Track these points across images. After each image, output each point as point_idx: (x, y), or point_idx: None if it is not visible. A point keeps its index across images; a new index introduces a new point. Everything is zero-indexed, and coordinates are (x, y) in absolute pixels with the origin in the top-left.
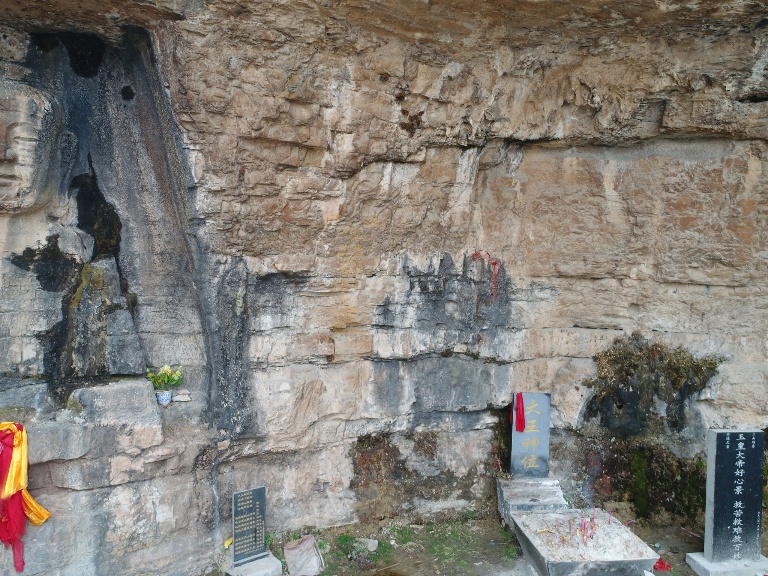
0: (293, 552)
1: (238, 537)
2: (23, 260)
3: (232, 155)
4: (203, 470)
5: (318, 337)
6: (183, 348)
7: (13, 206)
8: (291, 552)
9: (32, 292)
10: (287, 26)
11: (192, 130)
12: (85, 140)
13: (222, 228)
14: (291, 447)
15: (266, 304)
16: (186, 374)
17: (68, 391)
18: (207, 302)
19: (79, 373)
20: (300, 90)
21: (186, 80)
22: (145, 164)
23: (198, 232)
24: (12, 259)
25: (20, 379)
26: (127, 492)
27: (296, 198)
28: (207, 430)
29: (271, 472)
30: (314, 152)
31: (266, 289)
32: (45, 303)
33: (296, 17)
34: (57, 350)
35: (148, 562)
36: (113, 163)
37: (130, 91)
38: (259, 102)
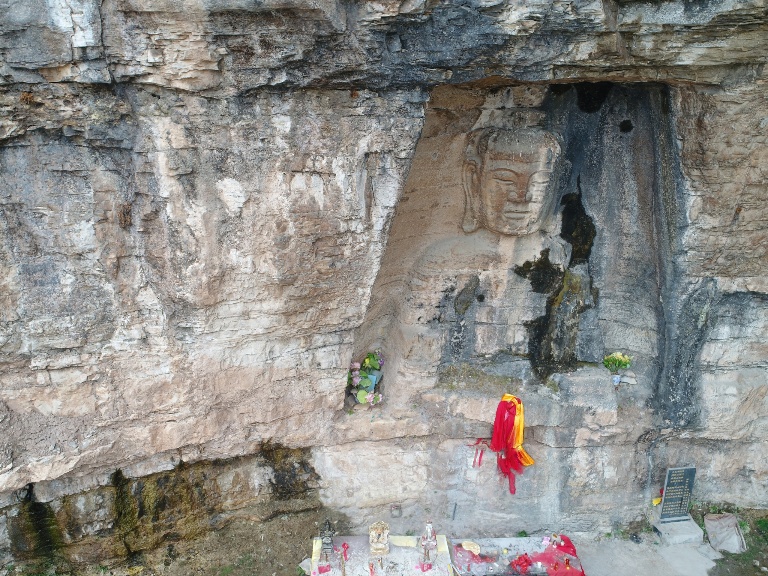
0: (713, 523)
1: (667, 502)
2: (523, 270)
3: (734, 201)
4: (643, 444)
5: None
6: (633, 337)
7: None
8: (711, 522)
9: (525, 293)
10: None
11: (698, 180)
12: (578, 165)
13: (703, 258)
14: (725, 438)
15: (725, 314)
16: (633, 358)
17: (547, 371)
18: (671, 314)
19: (555, 359)
20: None
21: (707, 143)
22: (630, 187)
23: (677, 260)
24: (515, 269)
25: (512, 356)
26: (584, 453)
27: None
28: (652, 415)
29: (700, 452)
30: None
31: (728, 300)
32: (534, 301)
33: None
34: (539, 337)
35: (595, 504)
36: (599, 184)
37: (629, 125)
38: None
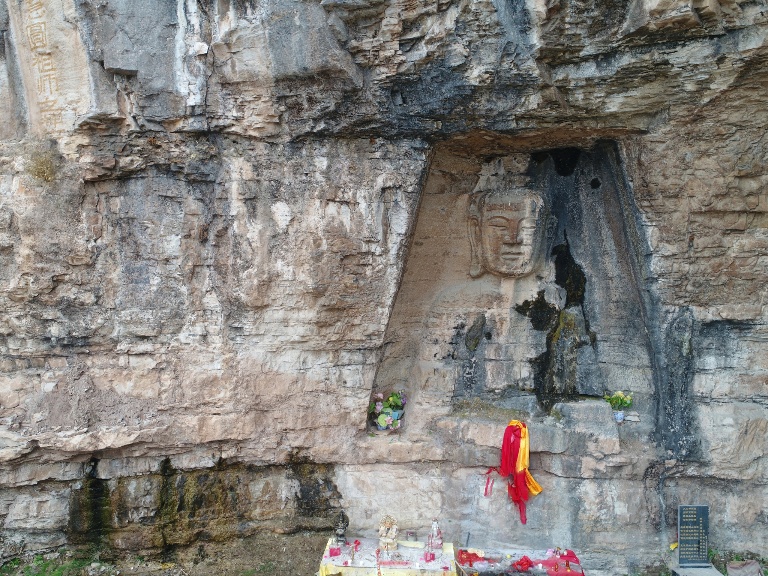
0: (736, 571)
1: (683, 543)
2: (523, 309)
3: (684, 227)
4: (652, 480)
5: (763, 379)
6: (633, 378)
7: (519, 273)
8: (734, 571)
9: (527, 331)
10: (739, 120)
11: (650, 211)
12: (562, 220)
13: (672, 285)
14: (734, 476)
15: (710, 346)
16: (635, 399)
17: (551, 403)
18: (657, 343)
19: (558, 391)
20: (749, 167)
21: (648, 176)
22: (607, 234)
23: (651, 288)
24: (516, 308)
25: (519, 391)
26: (593, 485)
27: (742, 256)
28: (655, 448)
29: (713, 495)
30: (762, 215)
31: (710, 333)
32: (535, 338)
33: (748, 111)
34: (543, 372)
35: (608, 543)
36: (582, 235)
37: (597, 182)
38: (710, 183)
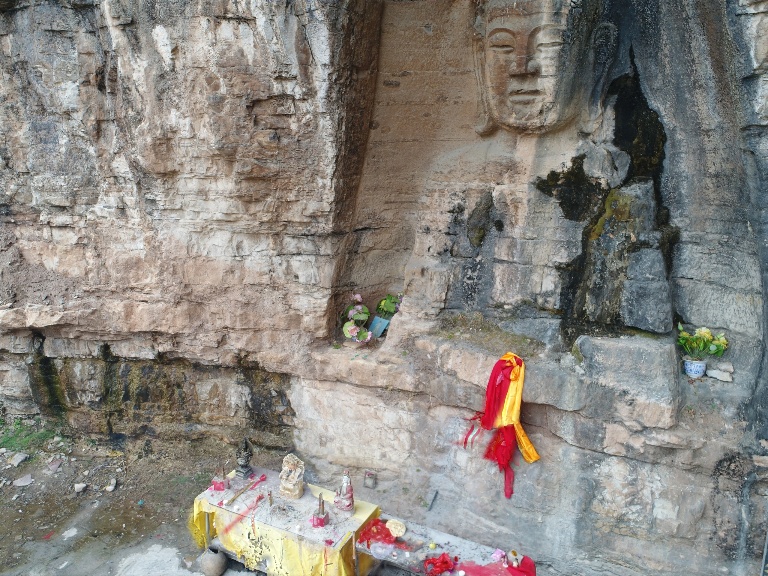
0: None
1: None
2: (547, 185)
3: None
4: (730, 480)
5: None
6: (735, 308)
7: (536, 125)
8: None
9: (555, 220)
10: None
11: None
12: (627, 29)
13: None
14: None
15: None
16: (735, 344)
17: (577, 334)
18: (767, 253)
19: (590, 317)
20: None
21: None
22: (699, 48)
23: (758, 147)
24: (537, 183)
25: (537, 310)
26: (623, 467)
27: None
28: (743, 431)
29: None
30: None
31: None
32: (567, 233)
33: None
34: (574, 286)
35: (636, 555)
36: (659, 54)
37: None
38: None
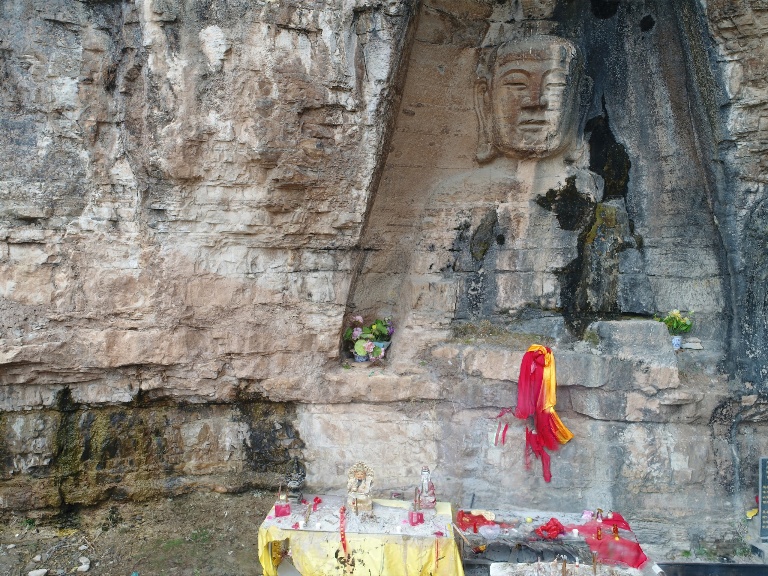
0: None
1: (766, 509)
2: (546, 201)
3: None
4: (721, 425)
5: None
6: (692, 293)
7: (542, 149)
8: None
9: (552, 231)
10: None
11: (731, 38)
12: (600, 82)
13: (757, 149)
14: None
15: None
16: (695, 321)
17: (584, 324)
18: (731, 238)
19: (593, 308)
20: None
21: None
22: (661, 95)
23: (726, 157)
24: (537, 200)
25: (541, 310)
26: (641, 431)
27: None
28: (726, 382)
29: None
30: None
31: None
32: (563, 241)
33: None
34: (572, 286)
35: (663, 508)
36: (626, 101)
37: (650, 20)
38: None
